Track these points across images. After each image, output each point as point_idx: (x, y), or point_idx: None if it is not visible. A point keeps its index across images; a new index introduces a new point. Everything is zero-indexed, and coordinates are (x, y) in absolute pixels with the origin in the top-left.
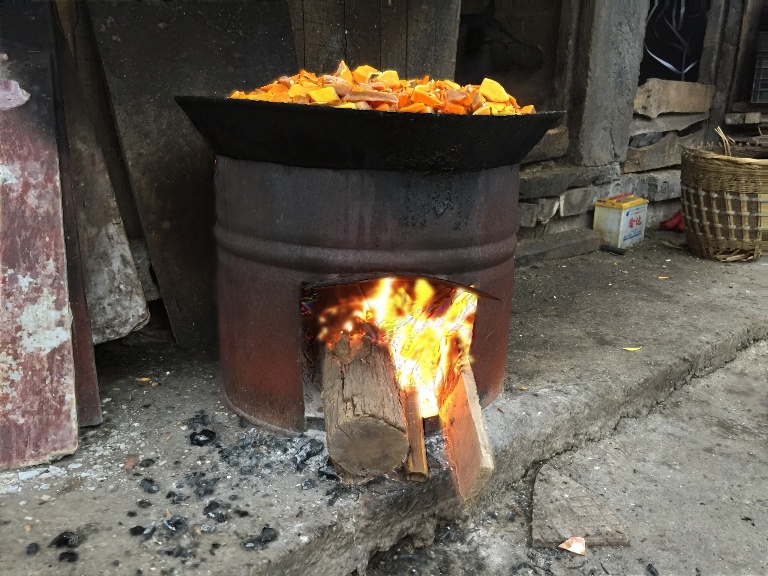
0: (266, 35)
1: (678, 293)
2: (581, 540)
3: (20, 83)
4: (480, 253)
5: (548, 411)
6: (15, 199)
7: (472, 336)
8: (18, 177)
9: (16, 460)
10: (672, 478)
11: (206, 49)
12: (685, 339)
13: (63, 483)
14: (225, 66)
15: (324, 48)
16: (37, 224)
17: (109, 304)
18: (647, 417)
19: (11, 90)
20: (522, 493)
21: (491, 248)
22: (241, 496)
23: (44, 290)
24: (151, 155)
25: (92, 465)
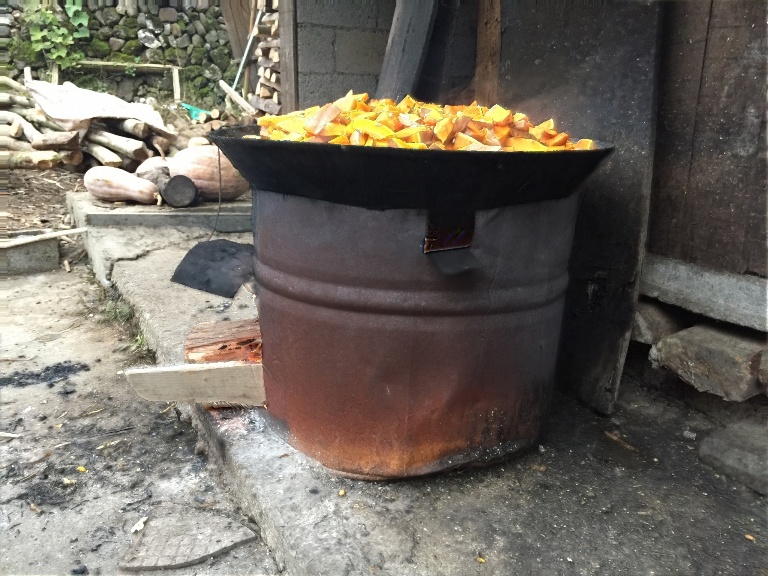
0: (622, 57)
1: None
2: (137, 523)
3: None
4: (259, 269)
5: (284, 499)
6: None
7: None
8: None
9: None
10: None
11: (564, 80)
12: None
13: None
14: (576, 95)
15: (735, 61)
16: None
17: None
18: None
19: None
20: (230, 516)
21: (267, 270)
22: None
23: None
24: None
25: None
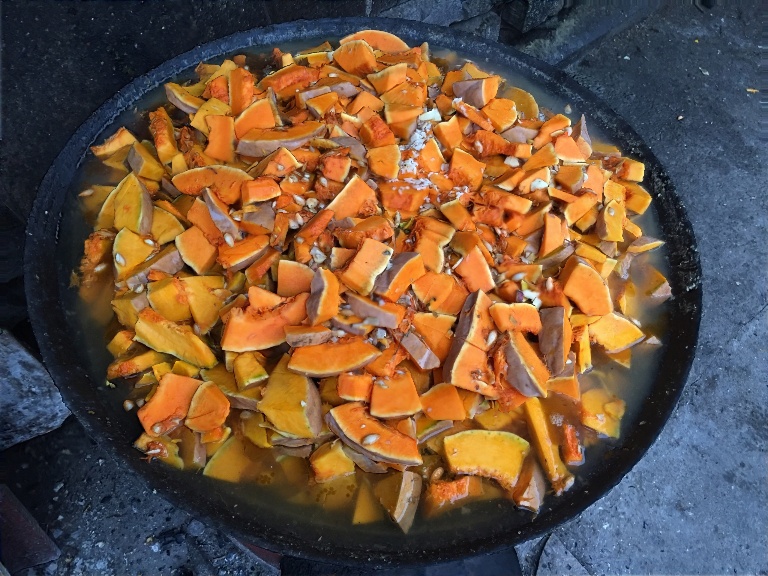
0: None
1: (764, 143)
2: None
3: None
4: None
5: None
6: None
7: None
8: None
9: None
10: (681, 535)
11: None
12: (750, 277)
13: None
14: None
15: None
16: None
17: (24, 408)
18: (675, 416)
19: None
20: None
21: None
22: None
23: None
24: (13, 155)
25: None
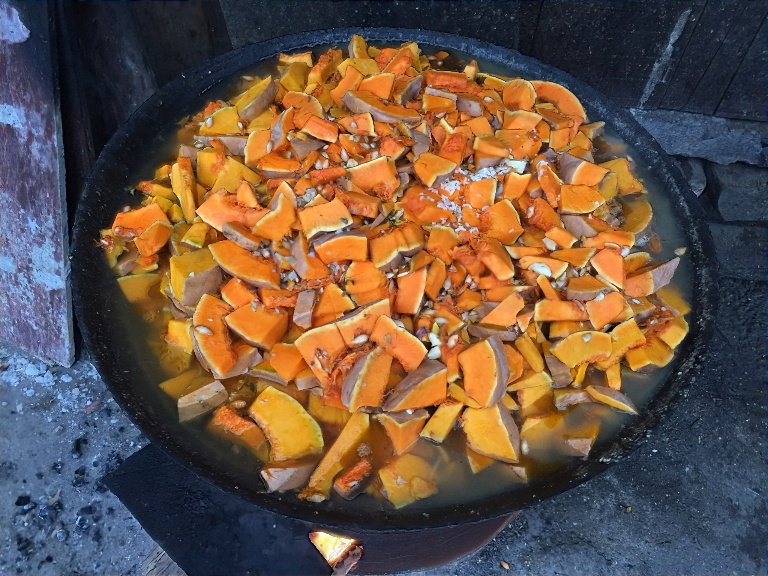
0: None
1: None
2: None
3: (20, 14)
4: None
5: None
6: (23, 145)
7: (361, 557)
8: (24, 124)
9: (33, 350)
10: None
11: None
12: None
13: (41, 398)
14: None
15: None
16: (40, 177)
17: None
18: None
19: (13, 21)
20: None
21: None
22: (116, 513)
23: (46, 239)
24: None
25: (75, 387)
